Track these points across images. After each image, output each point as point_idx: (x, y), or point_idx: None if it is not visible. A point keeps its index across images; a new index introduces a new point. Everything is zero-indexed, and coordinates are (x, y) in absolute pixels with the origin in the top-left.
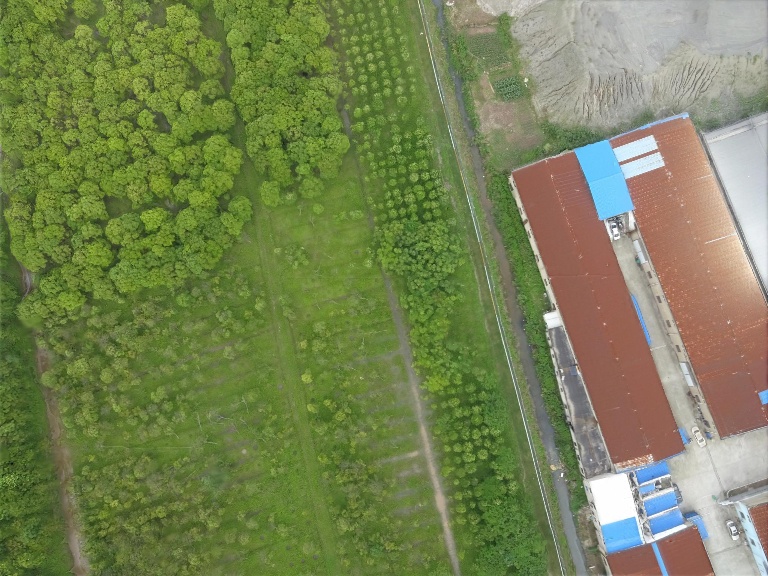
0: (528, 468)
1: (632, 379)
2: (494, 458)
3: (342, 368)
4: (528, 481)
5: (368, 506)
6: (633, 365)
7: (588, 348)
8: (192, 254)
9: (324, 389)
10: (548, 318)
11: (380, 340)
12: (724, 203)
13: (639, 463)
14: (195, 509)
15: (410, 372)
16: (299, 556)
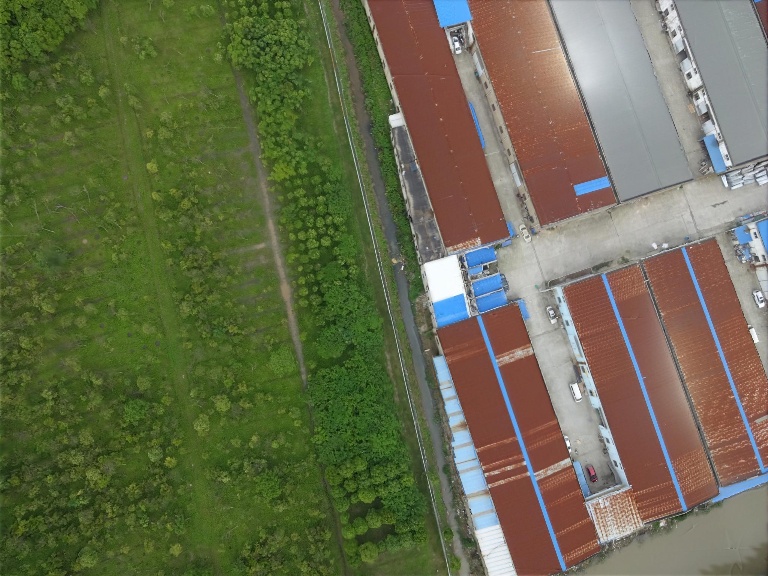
0: (370, 259)
1: (464, 170)
2: (336, 244)
3: (190, 161)
4: (370, 270)
5: (212, 291)
6: (465, 157)
7: (426, 142)
8: (29, 33)
9: (171, 181)
10: (392, 119)
11: (230, 137)
12: (551, 20)
13: (468, 246)
14: (29, 295)
15: (259, 168)
16: (140, 342)
